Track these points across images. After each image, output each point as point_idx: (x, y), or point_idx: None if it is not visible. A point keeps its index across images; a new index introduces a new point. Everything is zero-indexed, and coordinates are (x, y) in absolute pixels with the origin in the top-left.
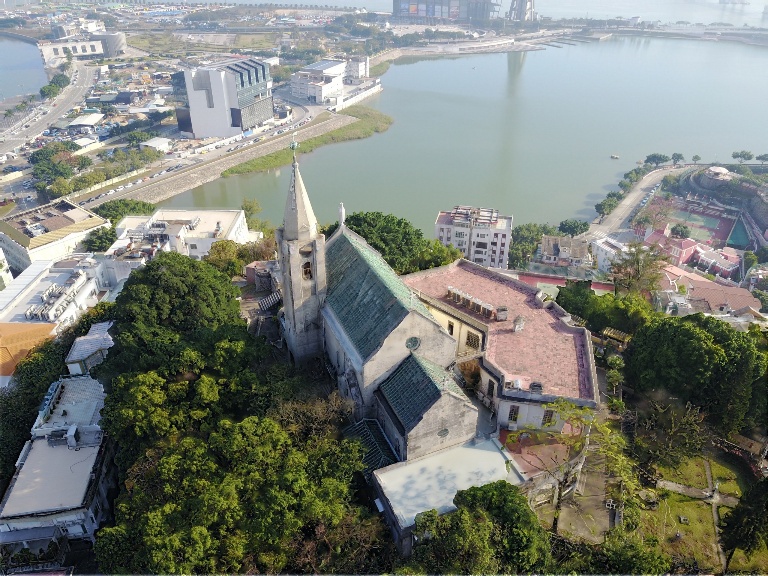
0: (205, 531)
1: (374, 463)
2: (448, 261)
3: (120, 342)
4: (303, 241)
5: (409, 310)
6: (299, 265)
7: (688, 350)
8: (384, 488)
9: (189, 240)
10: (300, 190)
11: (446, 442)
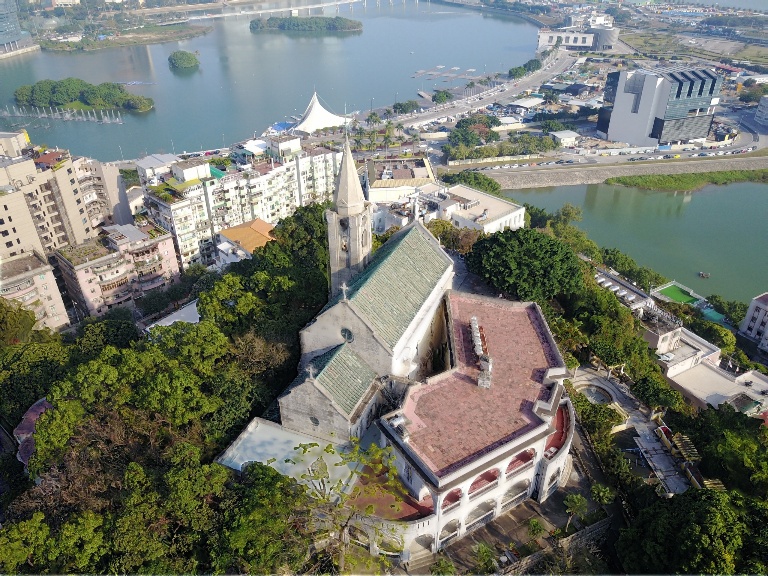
0: (115, 373)
1: (272, 415)
2: (601, 317)
3: (254, 252)
4: (342, 215)
5: (339, 300)
6: (337, 235)
7: (682, 533)
8: (251, 433)
9: (455, 216)
10: (347, 169)
11: (318, 432)
